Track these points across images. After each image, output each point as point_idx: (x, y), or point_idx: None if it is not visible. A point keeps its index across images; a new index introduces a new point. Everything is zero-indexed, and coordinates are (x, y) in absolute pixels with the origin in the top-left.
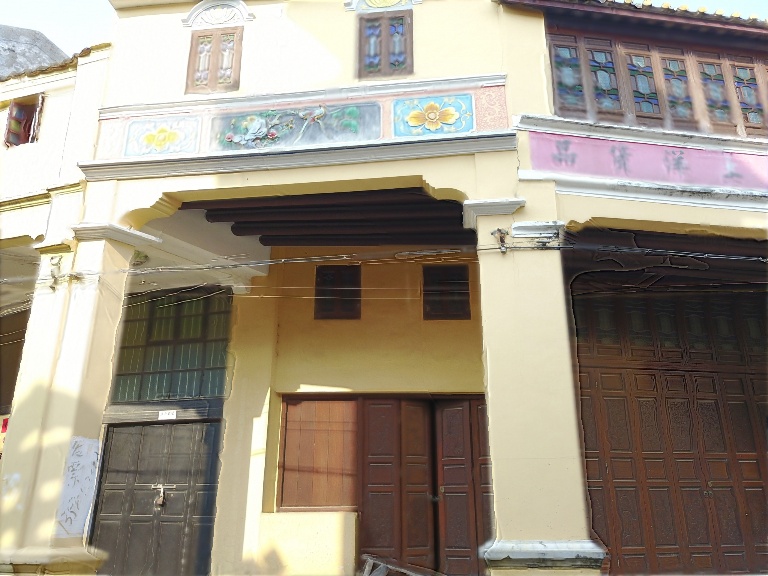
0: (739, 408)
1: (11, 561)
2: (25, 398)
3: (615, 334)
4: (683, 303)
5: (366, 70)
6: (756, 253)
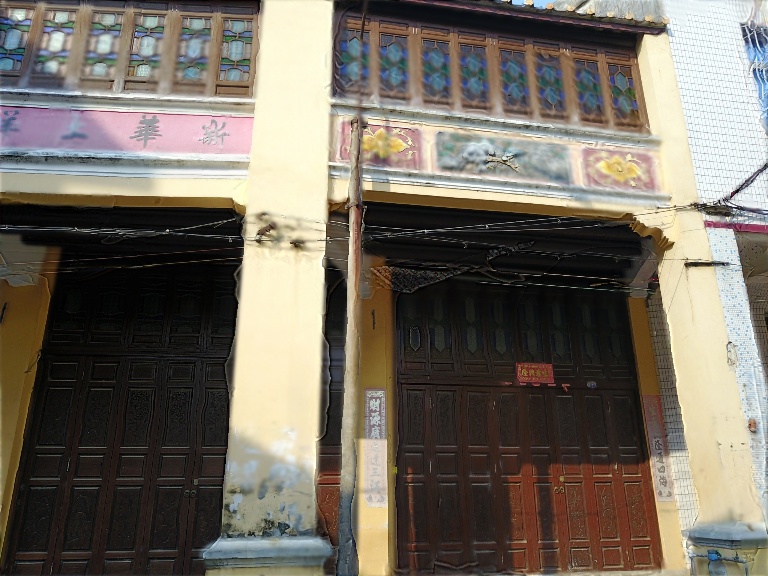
0: None
1: None
2: None
3: (120, 319)
4: (210, 283)
5: None
6: (72, 223)
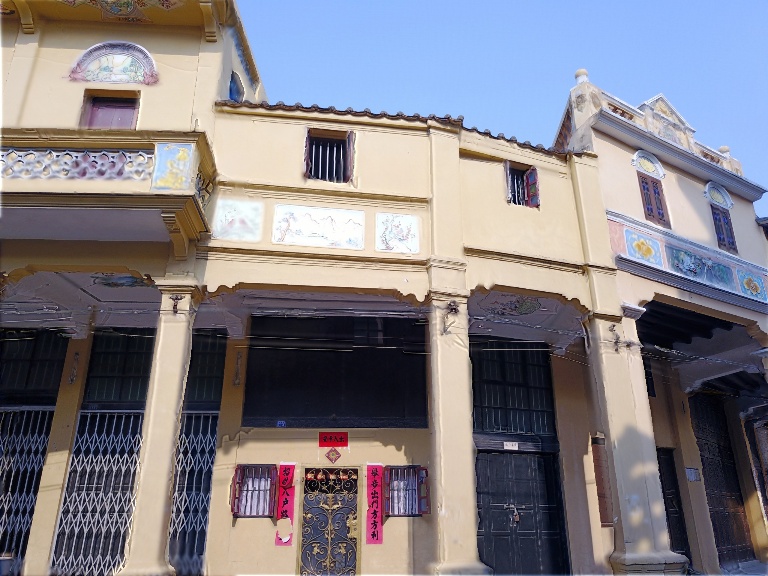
0: (723, 466)
1: (666, 561)
2: (621, 436)
3: (697, 417)
4: None
5: (719, 242)
6: None
